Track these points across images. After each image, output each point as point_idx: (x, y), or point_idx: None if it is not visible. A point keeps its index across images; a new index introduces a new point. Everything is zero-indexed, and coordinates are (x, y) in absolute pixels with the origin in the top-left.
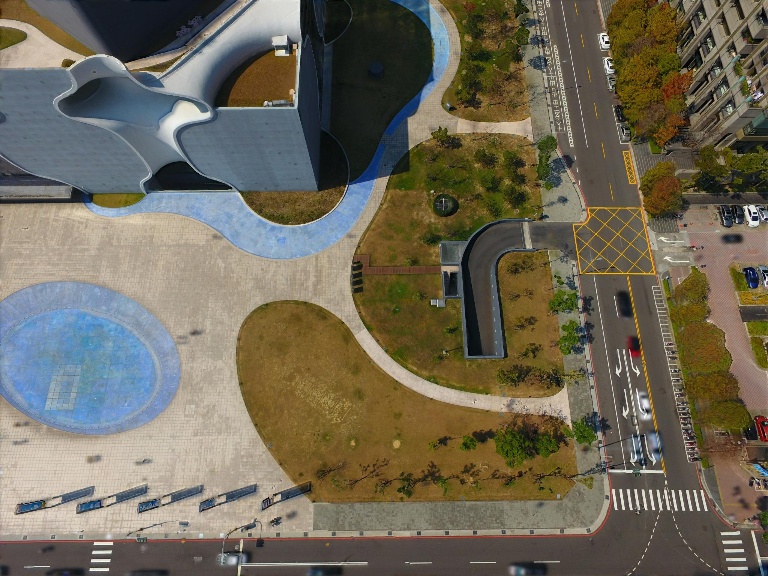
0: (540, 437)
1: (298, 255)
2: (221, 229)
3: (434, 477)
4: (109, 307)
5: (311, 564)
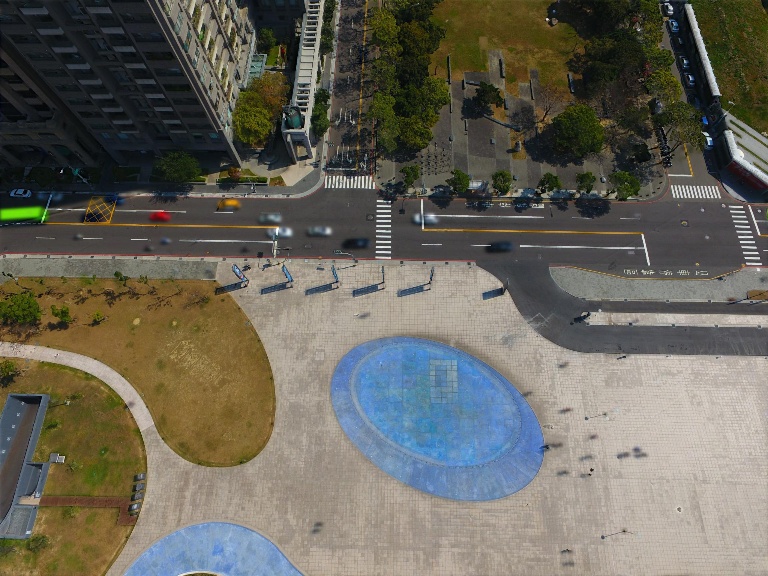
0: (2, 318)
1: (200, 528)
2: (291, 571)
3: (112, 295)
4: (414, 467)
5: (222, 241)
